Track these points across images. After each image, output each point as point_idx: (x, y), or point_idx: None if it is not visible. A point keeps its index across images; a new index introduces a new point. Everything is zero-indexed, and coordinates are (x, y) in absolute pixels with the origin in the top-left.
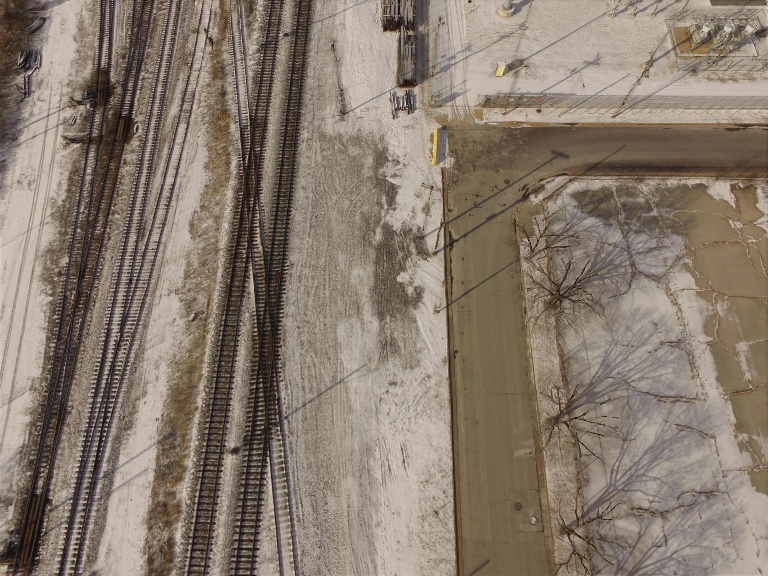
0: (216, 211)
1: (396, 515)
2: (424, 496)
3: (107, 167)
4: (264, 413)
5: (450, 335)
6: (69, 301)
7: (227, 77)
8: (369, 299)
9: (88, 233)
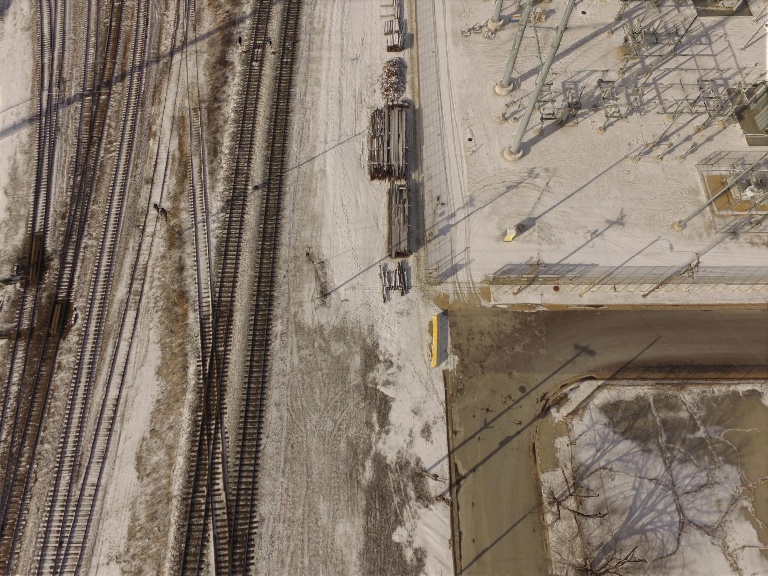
0: (169, 438)
1: None
2: None
3: (37, 374)
4: None
5: None
6: None
7: (186, 246)
8: (358, 569)
9: (10, 472)
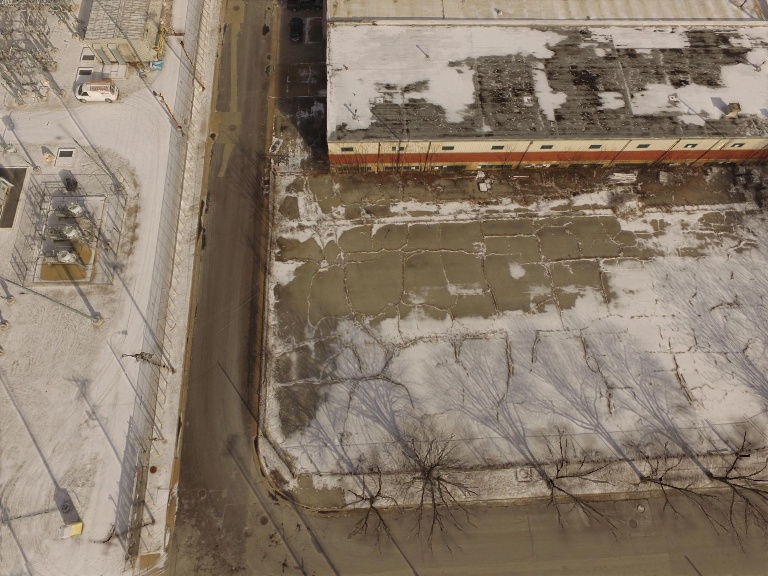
0: None
1: None
2: None
3: None
4: None
5: None
6: None
7: None
8: None
9: None
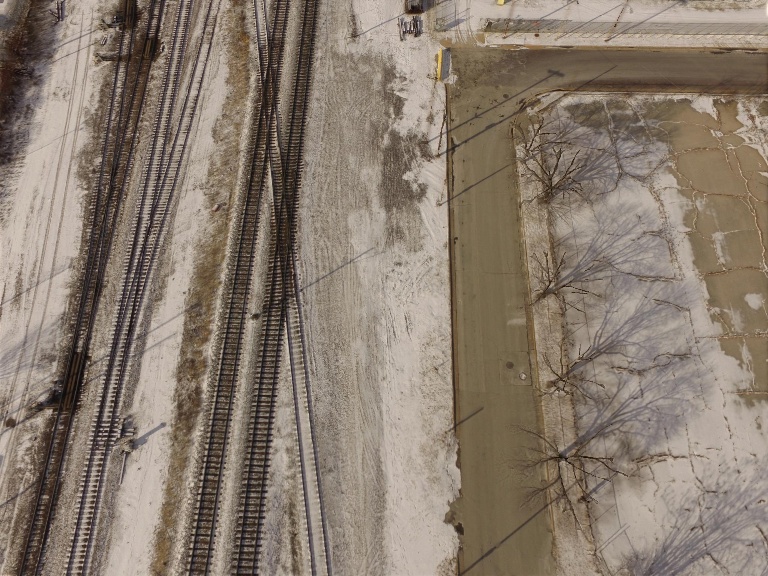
0: (237, 119)
1: (400, 371)
2: (425, 356)
3: (136, 81)
4: (281, 286)
5: (451, 224)
6: (103, 194)
7: (246, 4)
8: (377, 194)
9: (119, 137)
